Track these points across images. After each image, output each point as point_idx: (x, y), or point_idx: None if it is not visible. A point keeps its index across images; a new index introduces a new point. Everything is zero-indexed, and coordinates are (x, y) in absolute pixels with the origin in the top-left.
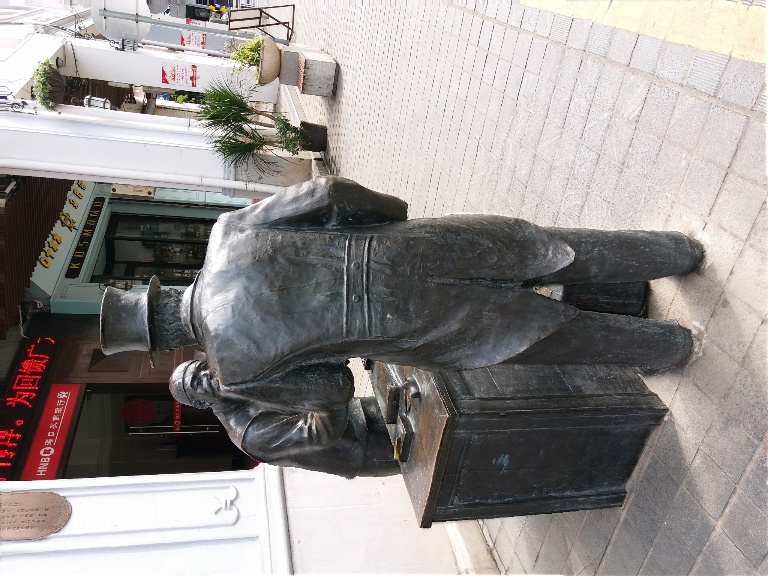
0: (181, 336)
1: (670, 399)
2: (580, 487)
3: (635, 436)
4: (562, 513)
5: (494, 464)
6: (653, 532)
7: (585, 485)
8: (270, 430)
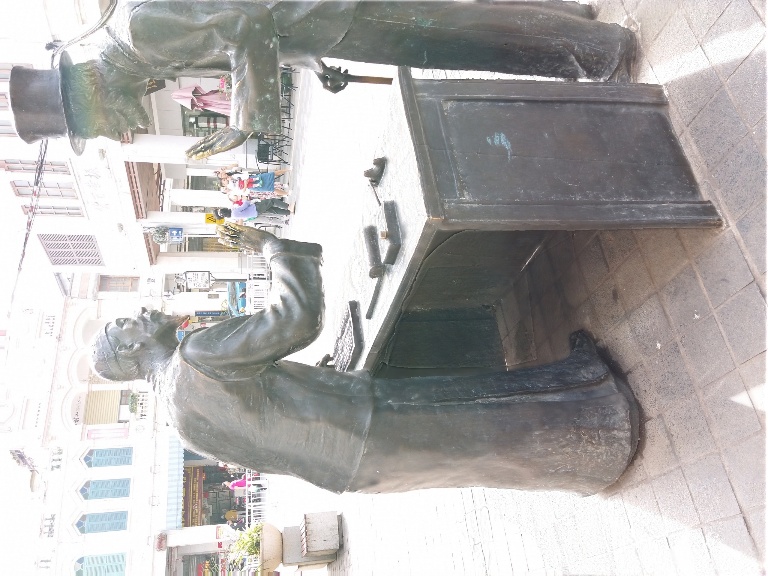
0: (96, 74)
1: (655, 81)
2: (637, 193)
3: (652, 123)
4: (706, 387)
5: (492, 146)
6: (759, 163)
7: (643, 191)
8: (219, 324)
